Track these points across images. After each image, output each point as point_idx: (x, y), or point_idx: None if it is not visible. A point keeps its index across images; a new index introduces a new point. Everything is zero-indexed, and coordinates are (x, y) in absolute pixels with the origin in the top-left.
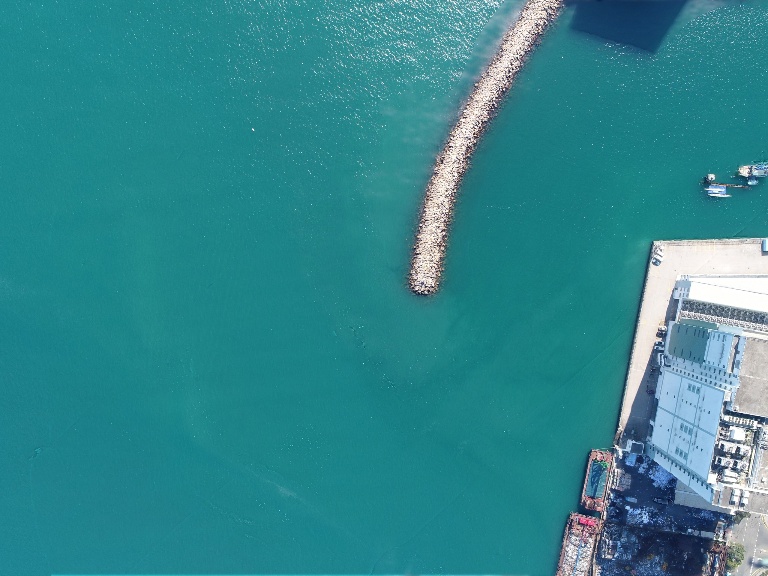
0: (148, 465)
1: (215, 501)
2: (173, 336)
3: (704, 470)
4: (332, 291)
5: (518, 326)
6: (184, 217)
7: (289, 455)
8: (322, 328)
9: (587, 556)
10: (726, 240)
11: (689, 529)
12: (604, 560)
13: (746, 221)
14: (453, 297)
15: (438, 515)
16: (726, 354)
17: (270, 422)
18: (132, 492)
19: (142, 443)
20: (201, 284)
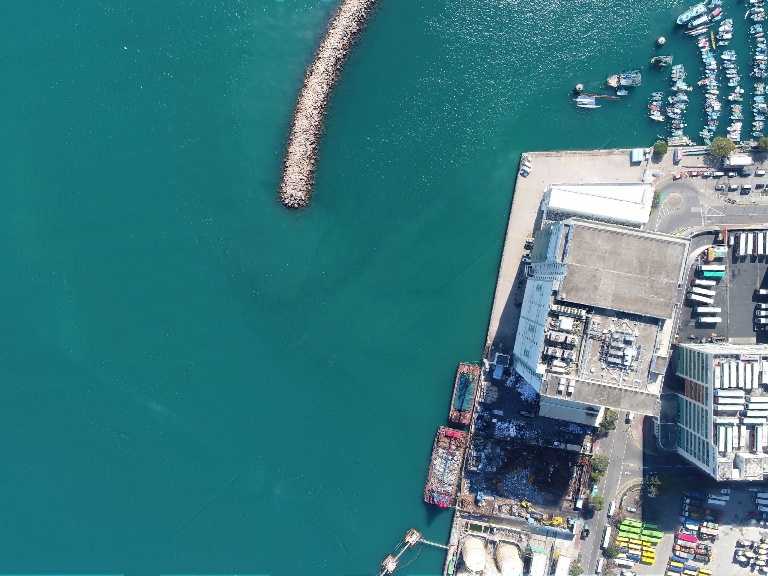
0: (27, 380)
1: (92, 416)
2: (44, 248)
3: (535, 362)
4: (194, 199)
5: (388, 239)
6: (47, 124)
7: (151, 362)
8: (184, 236)
9: (454, 469)
10: (594, 151)
11: (555, 442)
12: (473, 474)
13: (615, 132)
14: (324, 211)
15: (299, 423)
16: (557, 244)
17: (132, 329)
18: (8, 405)
19: (20, 358)
20: (65, 192)
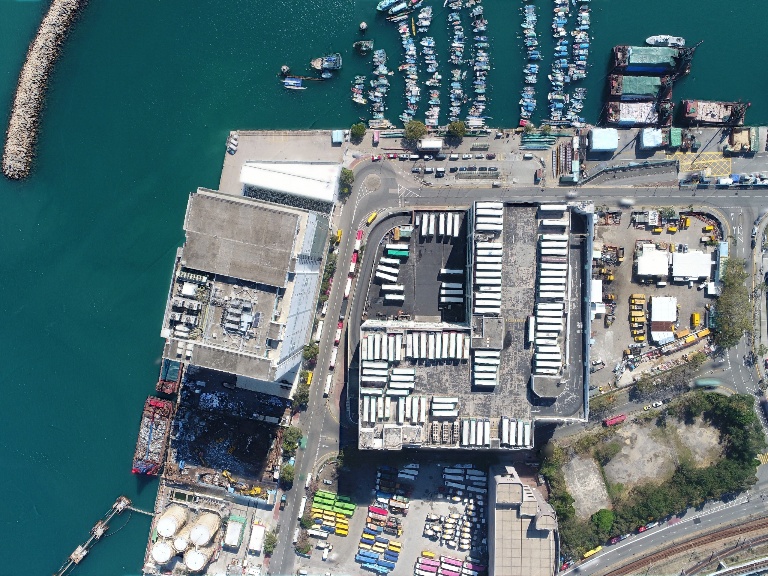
0: None
1: None
2: None
3: None
4: None
5: (104, 212)
6: None
7: None
8: None
9: (160, 438)
10: (297, 131)
11: (254, 414)
12: (179, 444)
13: (320, 113)
14: (45, 183)
15: None
16: None
17: None
18: None
19: None
20: None
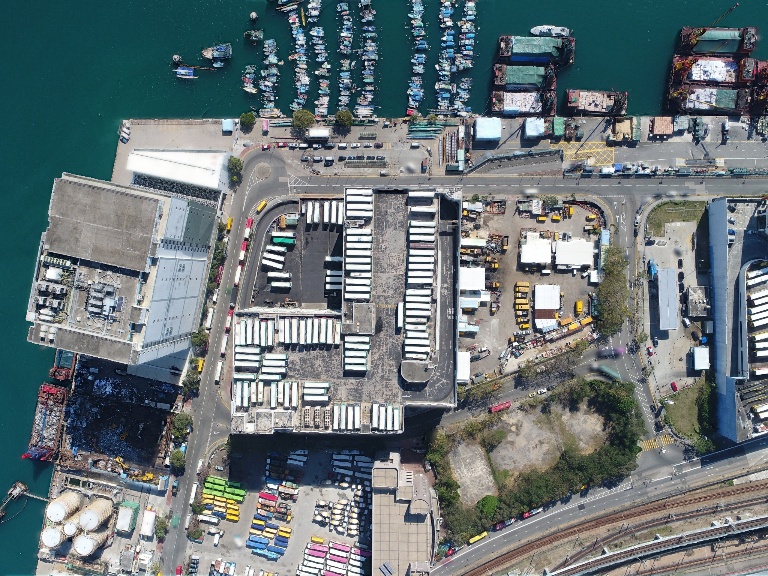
0: None
1: None
2: None
3: None
4: None
5: (1, 200)
6: None
7: None
8: None
9: (54, 424)
10: (189, 120)
11: (146, 400)
12: (74, 430)
13: (212, 103)
14: None
15: None
16: None
17: None
18: None
19: None
20: None
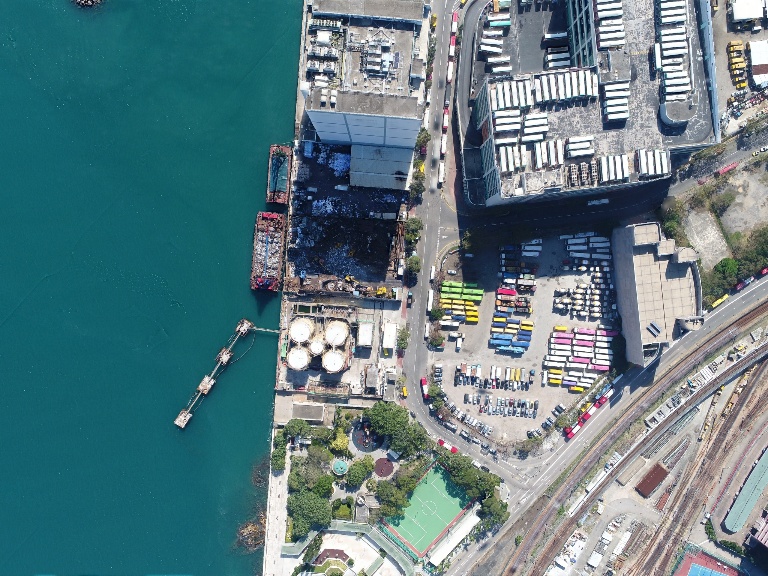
0: None
1: None
2: None
3: None
4: None
5: (187, 30)
6: None
7: None
8: None
9: (276, 252)
10: None
11: (371, 212)
12: (296, 256)
13: None
14: (120, 7)
15: (106, 211)
16: None
17: None
18: None
19: None
20: None
